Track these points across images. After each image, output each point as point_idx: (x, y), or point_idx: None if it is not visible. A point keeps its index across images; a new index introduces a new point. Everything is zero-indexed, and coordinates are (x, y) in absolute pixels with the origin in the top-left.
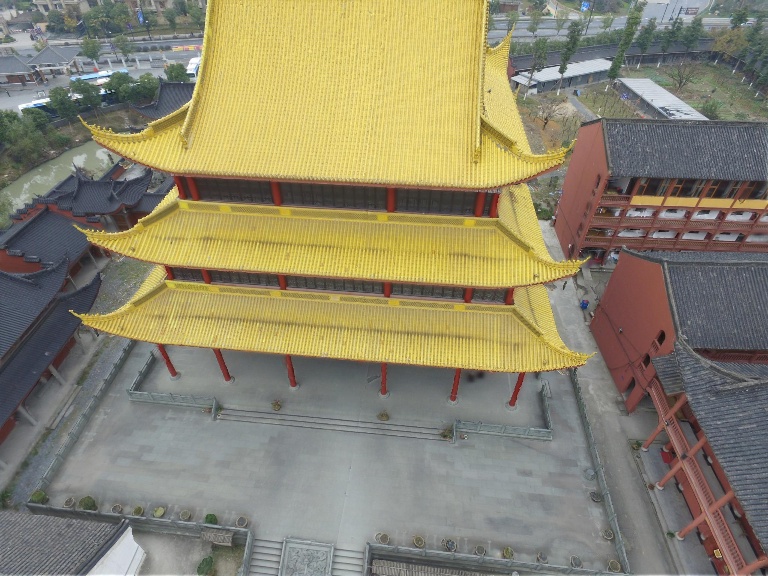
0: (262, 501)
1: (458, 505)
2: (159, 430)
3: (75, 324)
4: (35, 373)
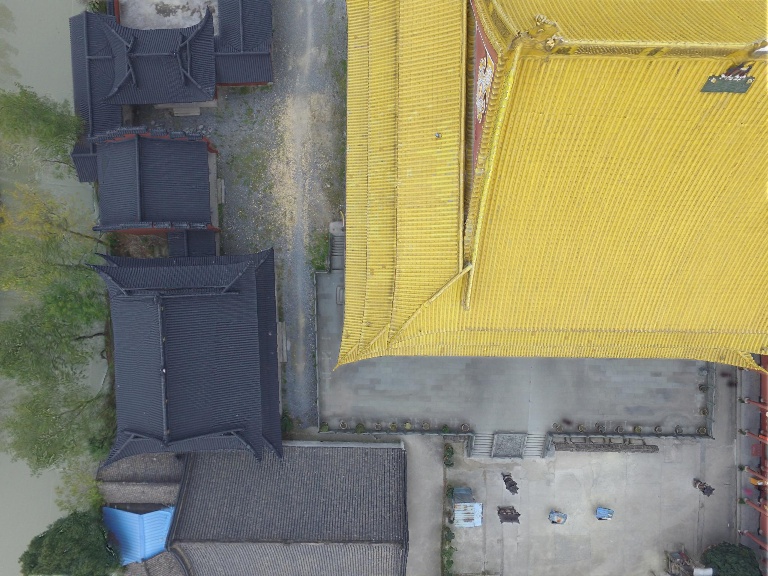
0: (473, 411)
1: (607, 401)
2: (378, 366)
3: (272, 297)
4: (273, 353)
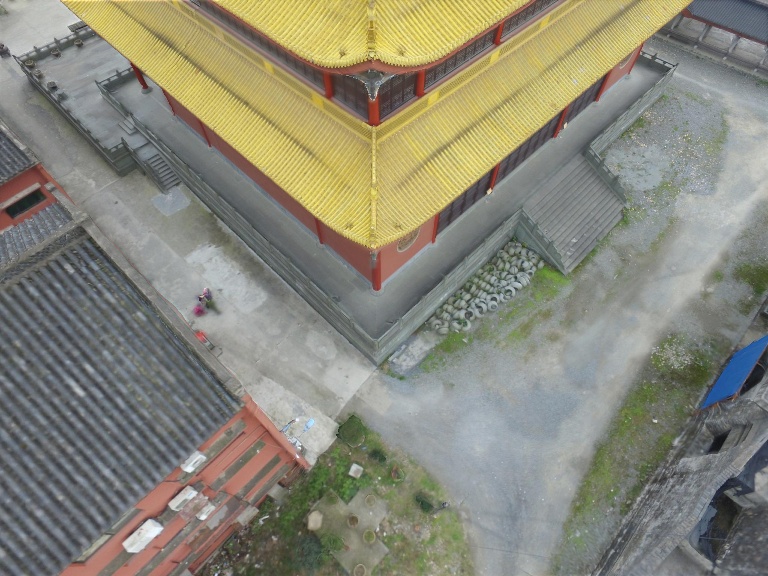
0: None
1: None
2: None
3: None
4: None
